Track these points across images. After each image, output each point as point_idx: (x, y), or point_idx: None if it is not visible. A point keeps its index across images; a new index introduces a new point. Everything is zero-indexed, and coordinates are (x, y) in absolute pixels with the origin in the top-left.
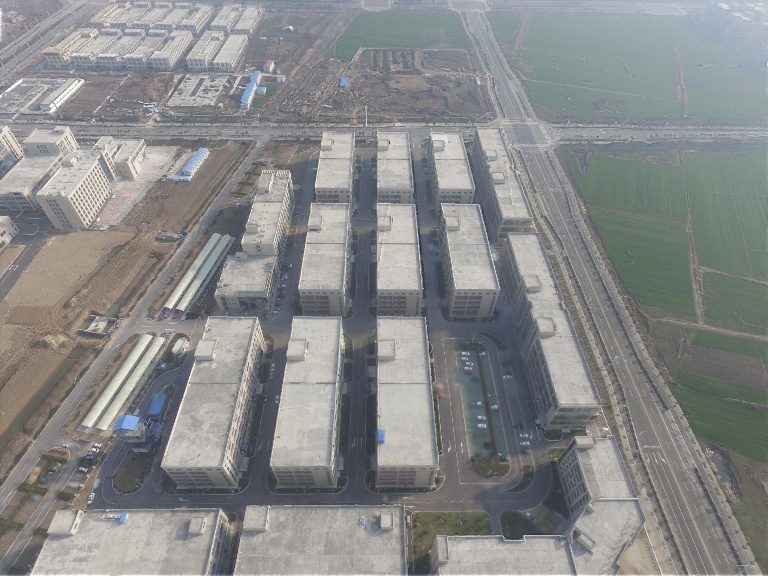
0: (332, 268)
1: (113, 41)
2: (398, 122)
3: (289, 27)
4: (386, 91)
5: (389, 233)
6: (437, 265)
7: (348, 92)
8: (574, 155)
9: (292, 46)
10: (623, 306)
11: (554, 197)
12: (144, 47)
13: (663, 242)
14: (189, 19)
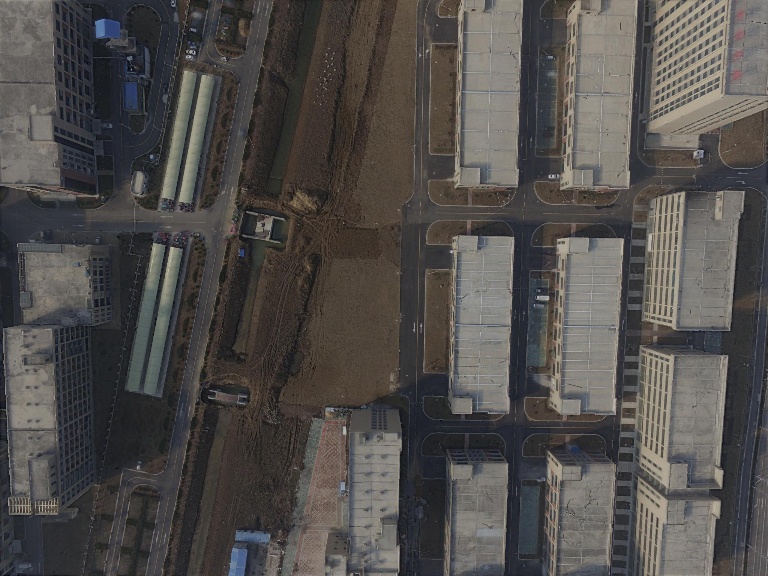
0: None
1: None
2: None
3: None
4: None
5: None
6: None
7: None
8: None
9: None
10: None
11: None
12: None
13: None
14: None
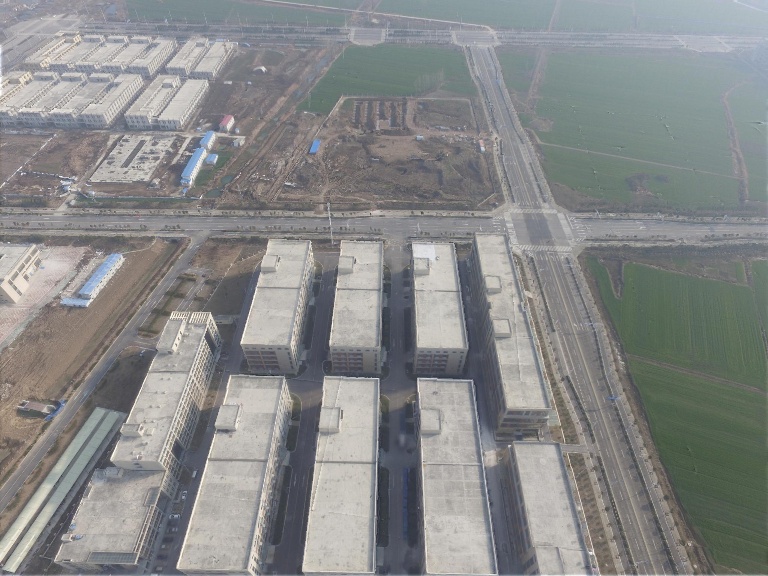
0: (238, 517)
1: (46, 88)
2: (377, 209)
3: (260, 68)
4: (366, 160)
5: (335, 439)
6: (408, 478)
7: (319, 162)
8: (605, 265)
9: (261, 93)
10: (688, 567)
11: (579, 340)
12: (80, 97)
13: (738, 428)
14: (142, 59)
